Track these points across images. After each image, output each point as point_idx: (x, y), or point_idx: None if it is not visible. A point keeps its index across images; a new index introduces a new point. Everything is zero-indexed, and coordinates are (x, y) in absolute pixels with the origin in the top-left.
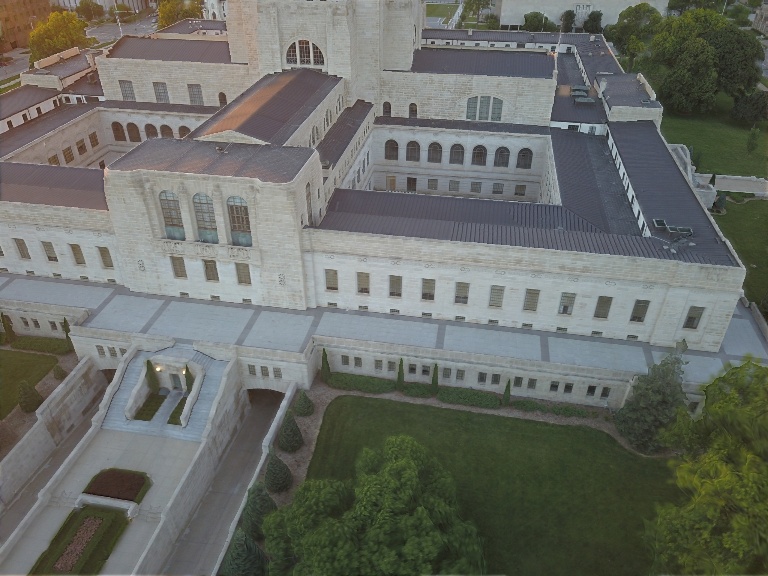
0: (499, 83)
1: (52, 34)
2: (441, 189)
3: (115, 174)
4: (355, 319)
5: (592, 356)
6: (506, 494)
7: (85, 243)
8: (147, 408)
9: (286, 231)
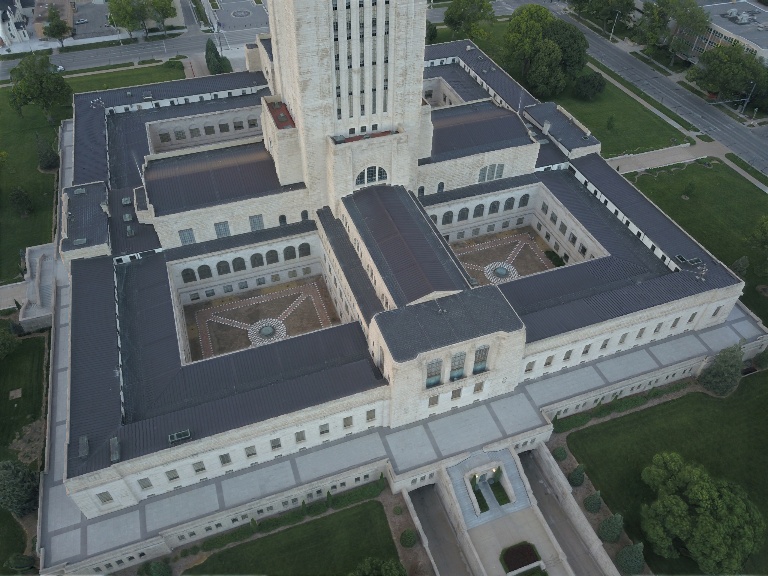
0: (502, 154)
1: None
2: (467, 236)
3: (406, 365)
4: (546, 383)
5: (678, 352)
6: (689, 451)
7: (359, 413)
8: (480, 503)
9: (516, 354)
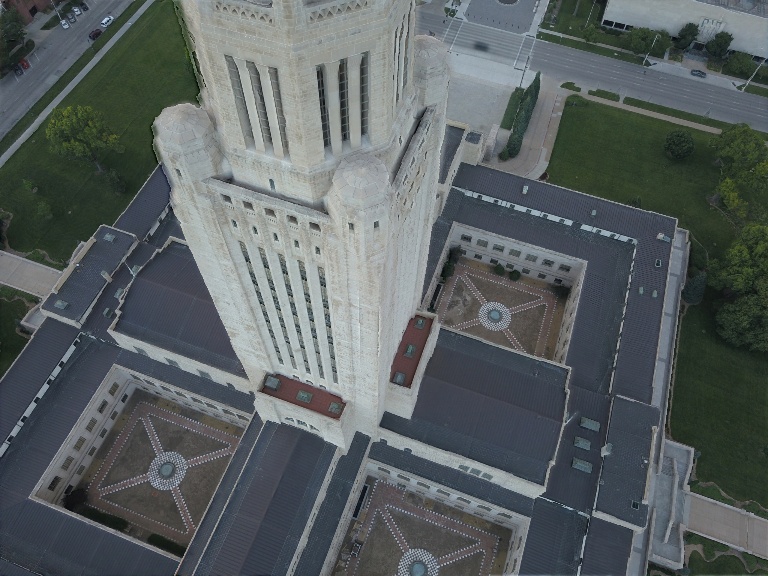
0: (491, 471)
1: (69, 135)
2: None
3: None
4: None
5: None
6: None
7: None
8: None
9: None
